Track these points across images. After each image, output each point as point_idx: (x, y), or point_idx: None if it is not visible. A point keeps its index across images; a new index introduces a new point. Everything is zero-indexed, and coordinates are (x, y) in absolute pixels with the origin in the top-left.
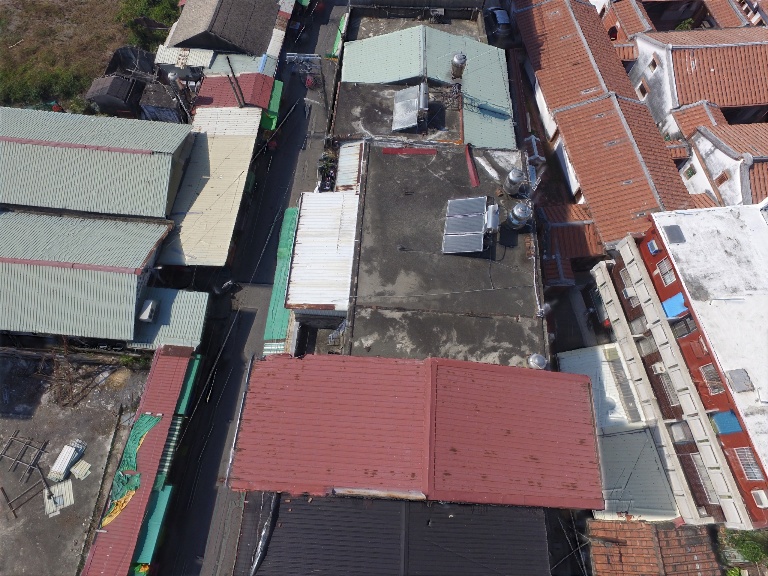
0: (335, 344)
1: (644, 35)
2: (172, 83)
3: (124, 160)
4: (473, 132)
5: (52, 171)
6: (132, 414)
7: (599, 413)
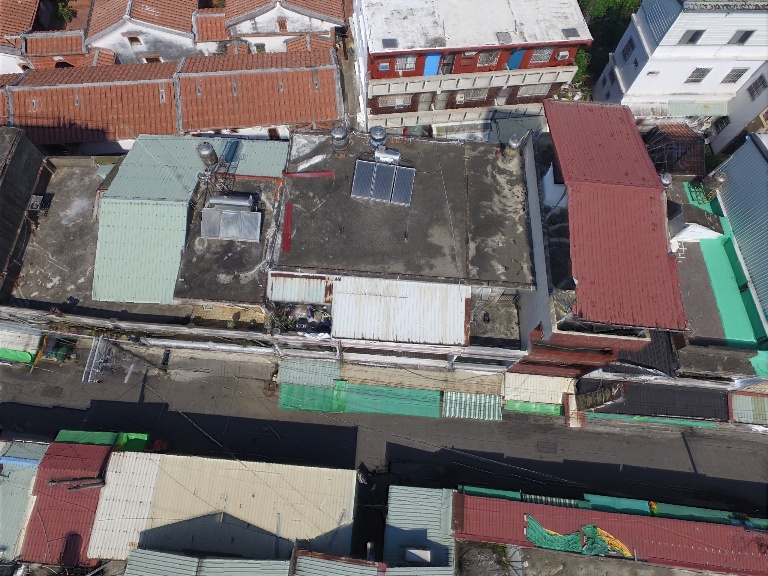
0: None
1: (93, 37)
2: None
3: None
4: (265, 170)
5: None
6: (510, 569)
7: None
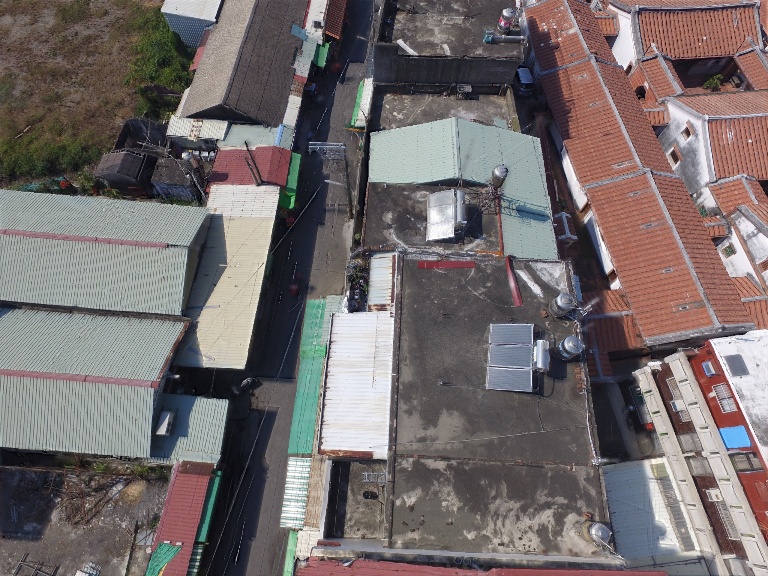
0: (370, 481)
1: (676, 101)
2: (186, 163)
3: (137, 254)
4: (512, 240)
5: (62, 267)
6: (148, 532)
7: (649, 540)
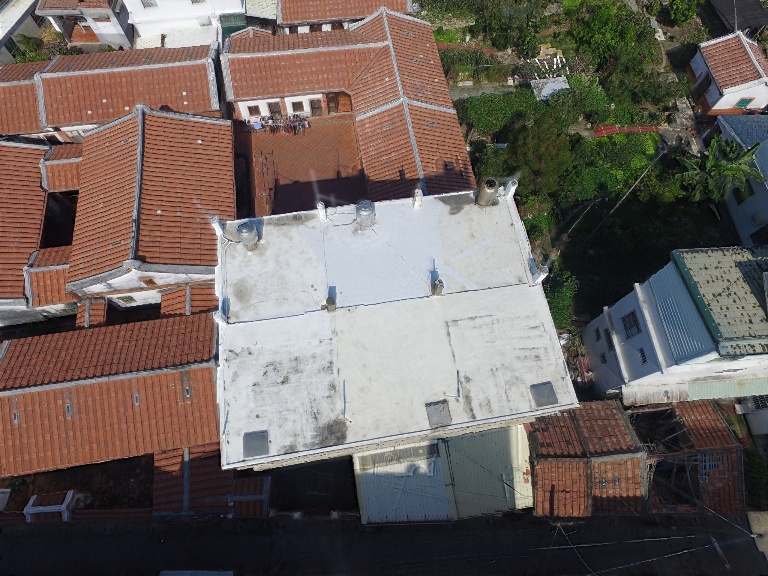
0: None
1: None
2: None
3: None
4: None
5: None
6: None
7: None
